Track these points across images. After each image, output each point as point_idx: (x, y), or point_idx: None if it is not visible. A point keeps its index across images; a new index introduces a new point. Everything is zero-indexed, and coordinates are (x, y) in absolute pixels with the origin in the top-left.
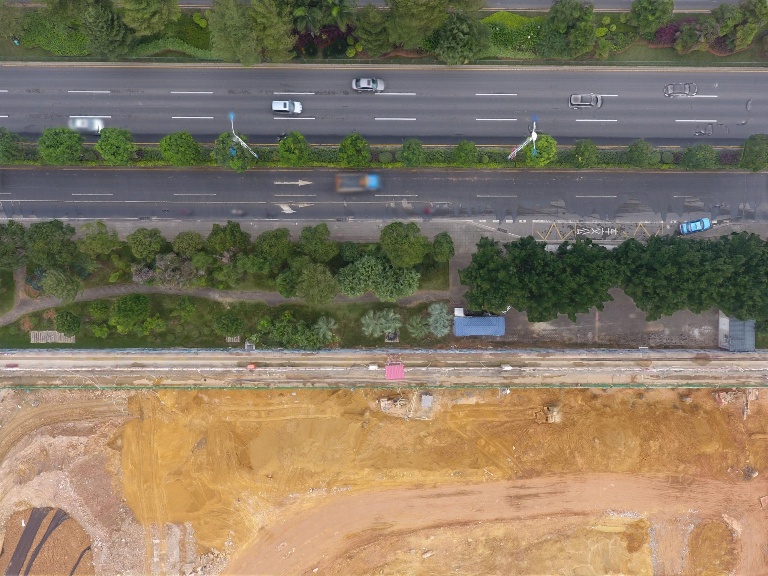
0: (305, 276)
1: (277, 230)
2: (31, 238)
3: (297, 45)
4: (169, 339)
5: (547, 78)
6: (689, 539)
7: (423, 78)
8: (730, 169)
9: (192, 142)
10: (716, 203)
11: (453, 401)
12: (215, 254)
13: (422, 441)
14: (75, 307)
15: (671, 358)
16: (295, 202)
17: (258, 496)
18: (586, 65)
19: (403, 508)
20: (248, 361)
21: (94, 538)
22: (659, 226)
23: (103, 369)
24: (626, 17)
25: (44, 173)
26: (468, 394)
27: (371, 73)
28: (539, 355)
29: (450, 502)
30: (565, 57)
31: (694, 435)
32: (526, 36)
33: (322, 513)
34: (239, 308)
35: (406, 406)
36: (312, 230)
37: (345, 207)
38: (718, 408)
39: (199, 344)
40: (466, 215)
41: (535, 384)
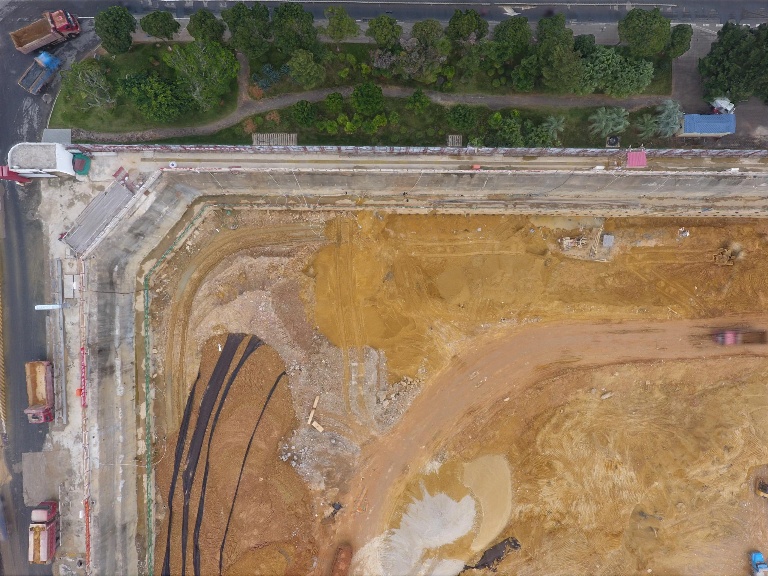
0: (556, 54)
1: None
2: (280, 17)
3: None
4: (394, 140)
5: None
6: None
7: None
8: None
9: None
10: None
11: (632, 243)
12: (458, 39)
13: (604, 281)
14: None
15: None
16: (519, 4)
17: (450, 325)
18: None
19: (590, 343)
20: (469, 165)
21: (289, 364)
22: None
23: (325, 172)
24: None
25: None
26: (647, 236)
27: None
28: (761, 161)
29: (635, 339)
30: None
31: None
32: None
33: (513, 343)
34: None
35: (587, 247)
36: (553, 17)
37: (568, 10)
38: None
39: None
40: (690, 19)
41: (737, 207)
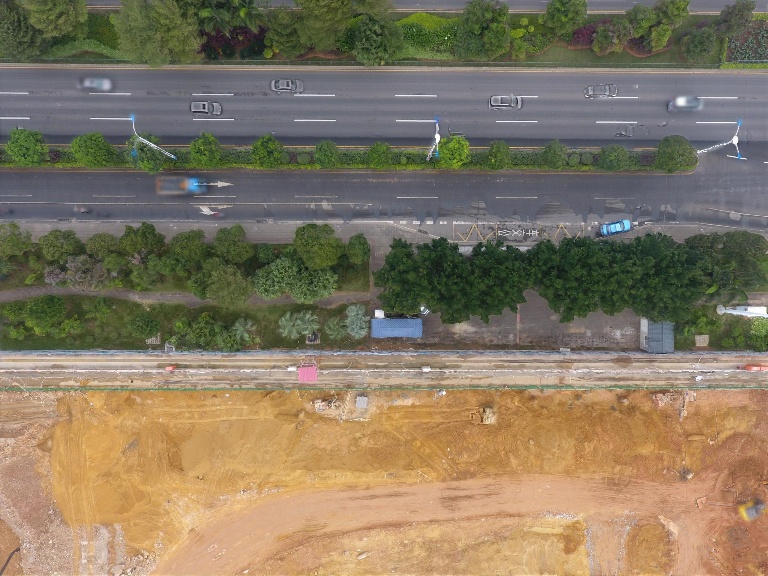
0: (215, 278)
1: (190, 232)
2: None
3: (214, 46)
4: (88, 341)
5: (467, 79)
6: (626, 541)
7: (342, 79)
8: (651, 170)
9: (103, 143)
10: (637, 204)
11: (389, 402)
12: (127, 256)
13: (357, 442)
14: None
15: (592, 360)
16: (214, 203)
17: (188, 498)
18: (505, 66)
19: (336, 510)
20: (168, 363)
21: (23, 540)
22: (580, 227)
23: (22, 371)
24: (543, 18)
25: None
26: (404, 395)
27: (290, 74)
28: (460, 357)
29: (383, 504)
30: (483, 58)
31: (629, 436)
32: (443, 37)
33: (253, 515)
34: (159, 310)
35: (341, 407)
36: (225, 232)
37: (265, 208)
38: (656, 409)
39: (119, 346)
40: (386, 216)
41: (463, 386)
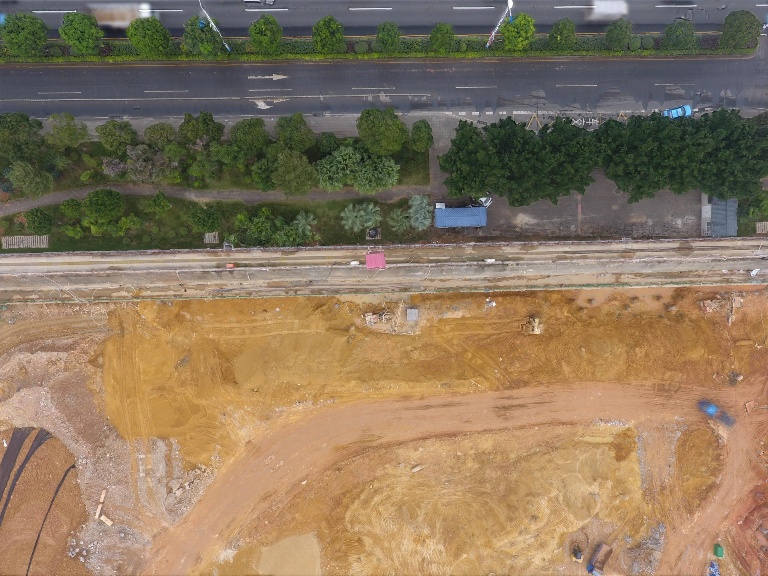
0: (280, 161)
1: (251, 118)
2: None
3: None
4: (145, 240)
5: None
6: (676, 446)
7: None
8: (711, 55)
9: (159, 26)
10: (697, 90)
11: (439, 315)
12: (188, 144)
13: (408, 355)
14: (47, 210)
15: (654, 249)
16: (270, 97)
17: (244, 410)
18: None
19: (391, 420)
20: (227, 262)
21: (78, 456)
22: None
23: (78, 273)
24: None
25: (8, 71)
26: (454, 308)
27: None
28: (522, 249)
29: (438, 414)
30: None
31: (679, 341)
32: None
33: (309, 426)
34: (216, 208)
35: (392, 321)
36: (287, 118)
37: (321, 101)
38: (703, 317)
39: (176, 246)
40: (445, 107)
41: (520, 286)
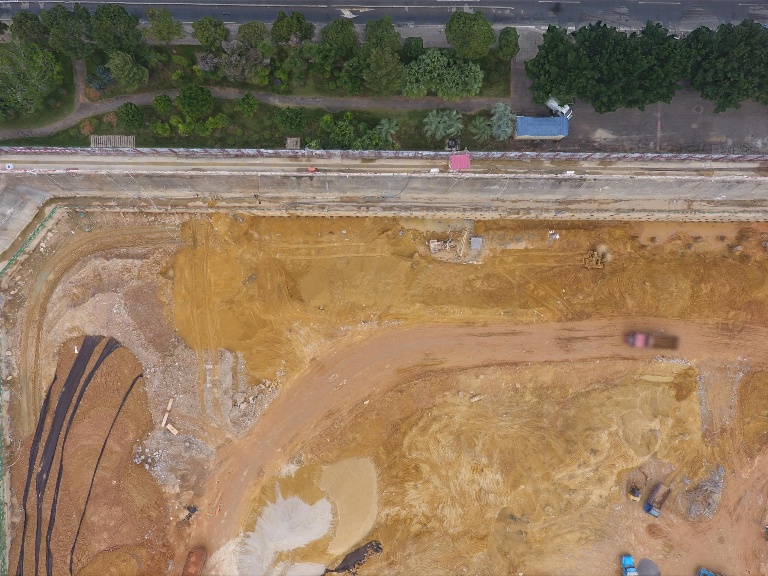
0: (373, 57)
1: None
2: (98, 19)
3: None
4: (229, 142)
5: None
6: (738, 387)
7: None
8: None
9: None
10: None
11: (502, 246)
12: (281, 41)
13: (471, 283)
14: None
15: (733, 168)
16: (356, 6)
17: (310, 327)
18: None
19: (453, 345)
20: (308, 167)
21: (146, 366)
22: None
23: (163, 174)
24: None
25: None
26: (517, 239)
27: None
28: (600, 164)
29: (500, 342)
30: None
31: (745, 279)
32: None
33: (373, 346)
34: None
35: (455, 249)
36: (378, 20)
37: (406, 12)
38: (767, 259)
39: None
40: (528, 21)
41: (591, 210)
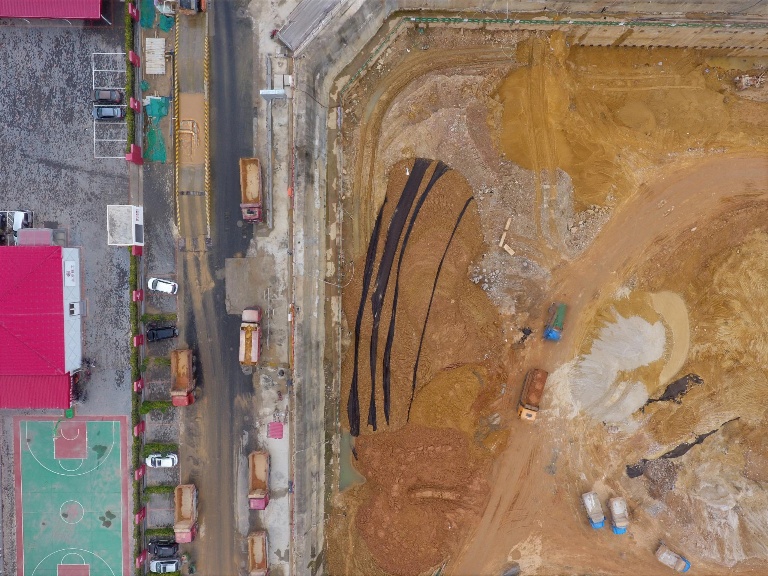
0: None
1: None
2: None
3: None
4: None
5: None
6: None
7: None
8: None
9: None
10: None
11: None
12: None
13: None
14: None
15: None
16: None
17: (638, 153)
18: None
19: None
20: None
21: (476, 190)
22: None
23: None
24: None
25: None
26: None
27: None
28: None
29: None
30: None
31: None
32: None
33: (700, 173)
34: None
35: (763, 86)
36: None
37: None
38: None
39: None
40: None
41: None
